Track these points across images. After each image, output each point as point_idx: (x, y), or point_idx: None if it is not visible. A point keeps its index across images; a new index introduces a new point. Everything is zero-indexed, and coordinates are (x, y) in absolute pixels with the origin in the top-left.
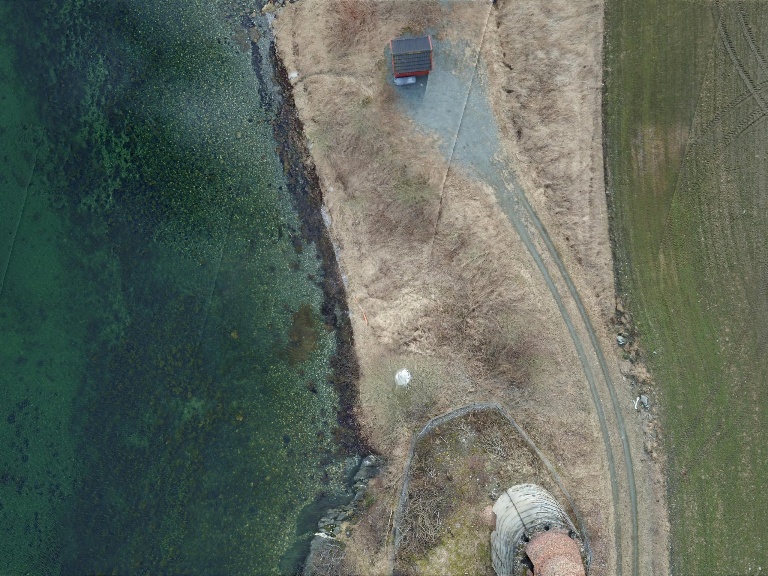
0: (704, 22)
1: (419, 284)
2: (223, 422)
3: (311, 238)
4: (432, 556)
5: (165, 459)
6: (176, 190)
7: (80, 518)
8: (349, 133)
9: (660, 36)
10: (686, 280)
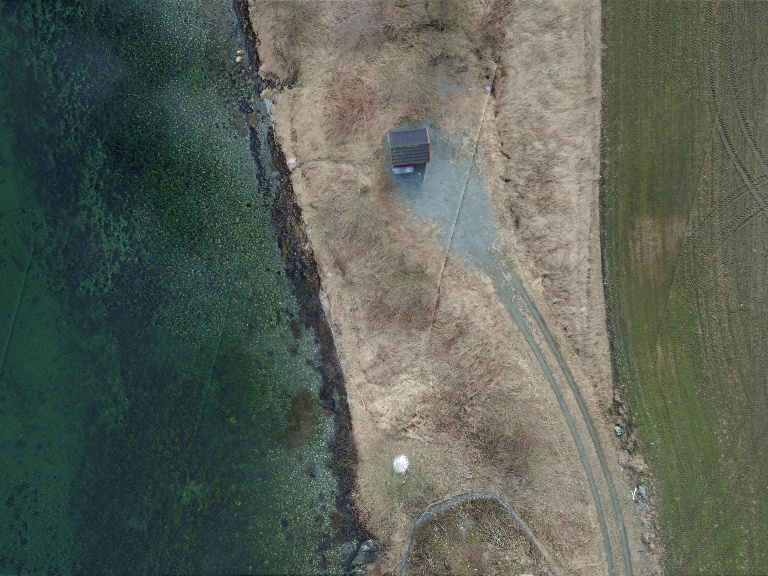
0: (701, 116)
1: (417, 371)
2: (221, 506)
3: (309, 323)
4: None
5: (164, 542)
6: (174, 274)
7: None
8: (347, 220)
9: (657, 129)
10: (684, 372)
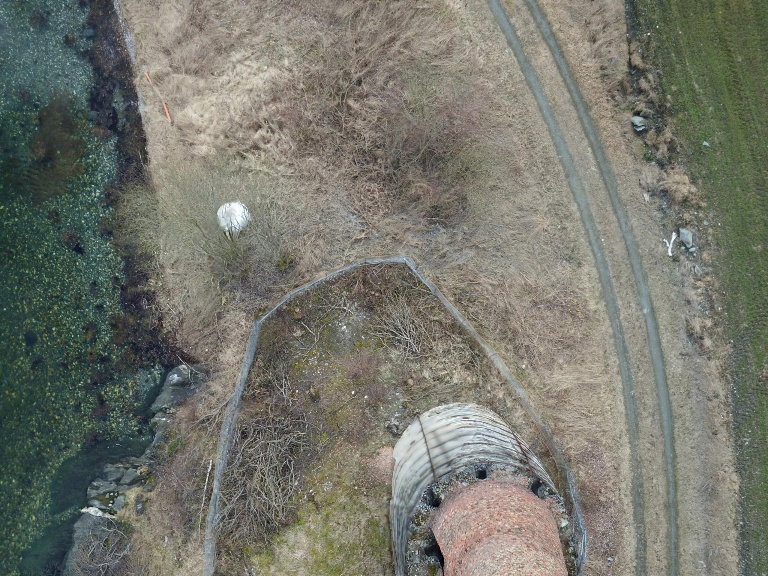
0: None
1: (260, 41)
2: None
3: None
4: (280, 546)
5: None
6: None
7: None
8: None
9: None
10: None
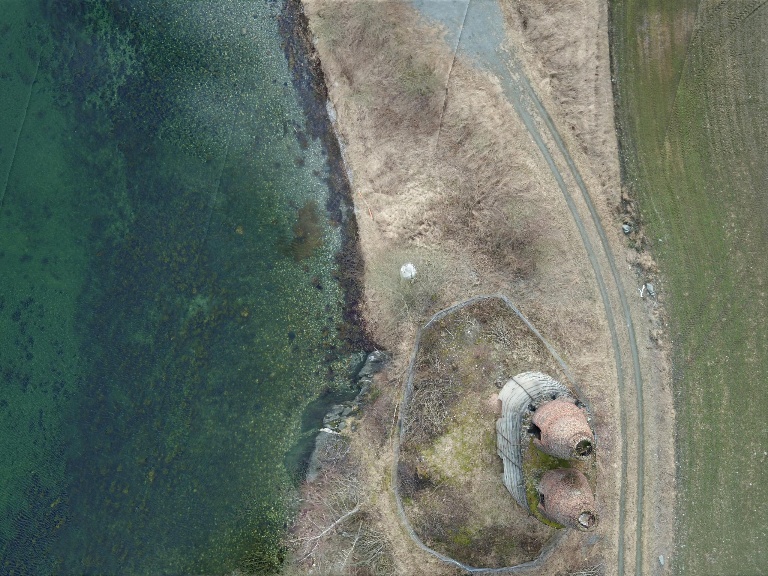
0: None
1: (424, 177)
2: (228, 319)
3: (316, 134)
4: (438, 445)
5: (170, 356)
6: (181, 87)
7: (85, 415)
8: (354, 26)
9: None
10: (692, 167)
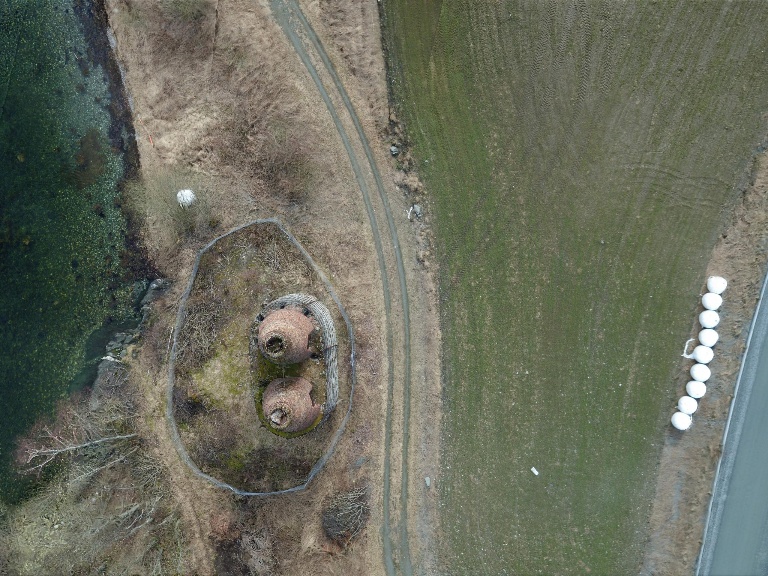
0: None
1: (201, 103)
2: (12, 248)
3: (97, 61)
4: (207, 369)
5: None
6: None
7: None
8: None
9: None
10: (456, 87)
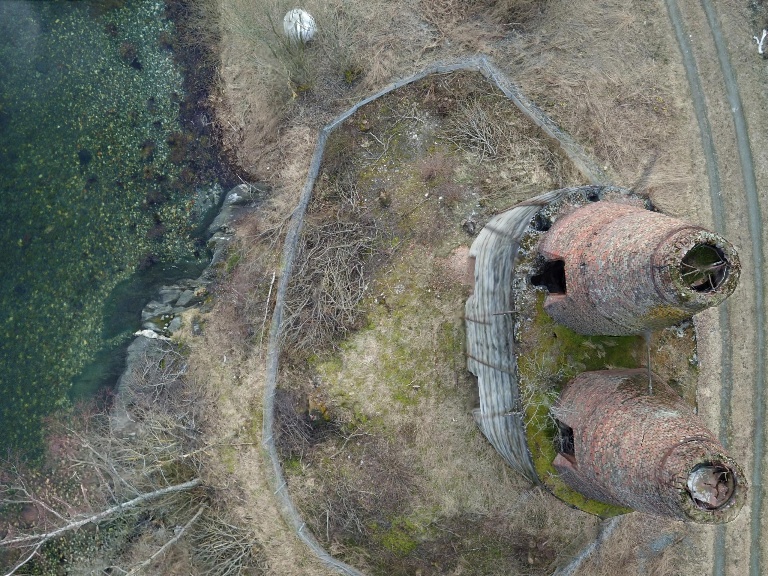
0: None
1: None
2: None
3: None
4: (348, 353)
5: None
6: None
7: None
8: None
9: None
10: None
